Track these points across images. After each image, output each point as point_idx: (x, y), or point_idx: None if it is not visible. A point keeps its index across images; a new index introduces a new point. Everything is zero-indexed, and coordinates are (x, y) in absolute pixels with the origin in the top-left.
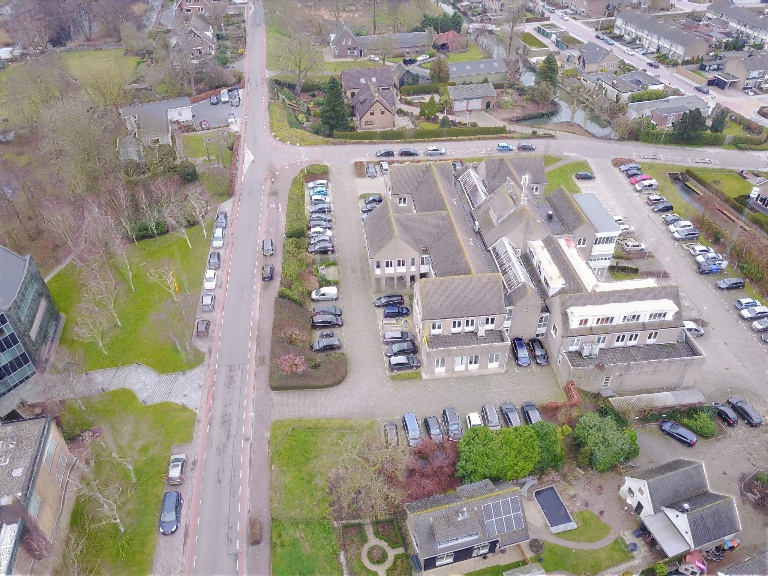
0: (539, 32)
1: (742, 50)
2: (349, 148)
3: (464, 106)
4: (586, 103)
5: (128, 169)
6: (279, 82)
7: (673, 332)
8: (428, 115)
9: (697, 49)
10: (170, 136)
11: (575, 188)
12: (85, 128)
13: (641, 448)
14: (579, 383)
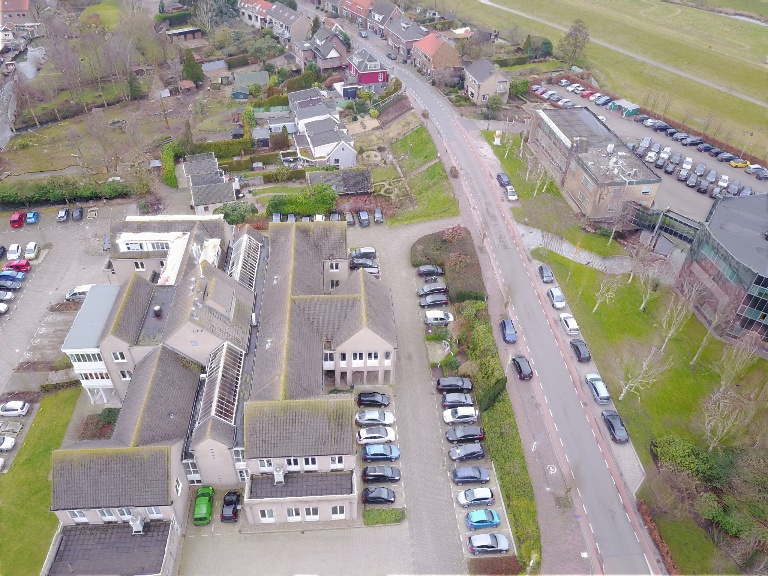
0: None
1: None
2: None
3: None
4: None
5: None
6: None
7: None
8: None
9: None
10: None
11: None
12: None
13: None
14: None
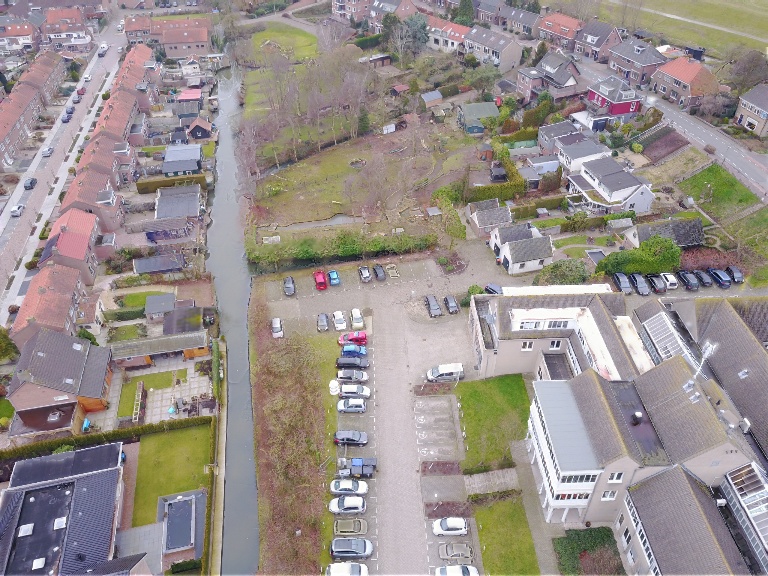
0: None
1: None
2: None
3: None
4: None
5: None
6: None
7: None
8: None
9: None
10: None
11: None
12: None
13: None
14: None
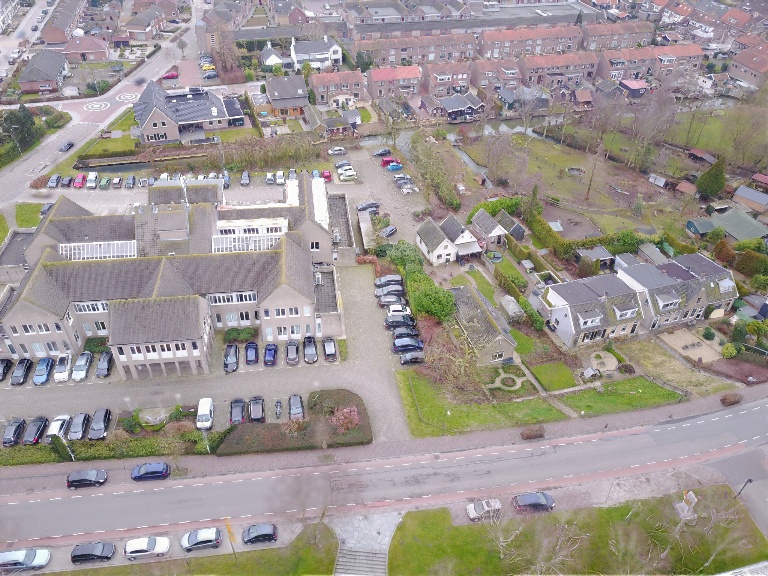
0: None
1: None
2: None
3: None
4: None
5: None
6: None
7: None
8: None
9: None
10: None
11: None
12: None
13: None
14: None
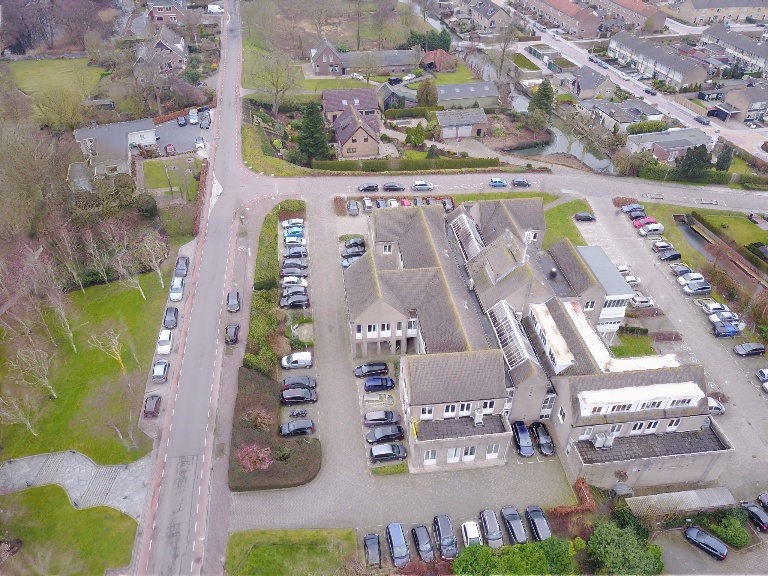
0: (530, 52)
1: (741, 79)
2: (329, 180)
3: (453, 133)
4: (584, 135)
5: (80, 200)
6: (254, 102)
7: (697, 419)
8: (415, 143)
9: (695, 77)
10: (130, 162)
11: (575, 231)
12: (26, 159)
13: (664, 562)
14: (591, 480)
